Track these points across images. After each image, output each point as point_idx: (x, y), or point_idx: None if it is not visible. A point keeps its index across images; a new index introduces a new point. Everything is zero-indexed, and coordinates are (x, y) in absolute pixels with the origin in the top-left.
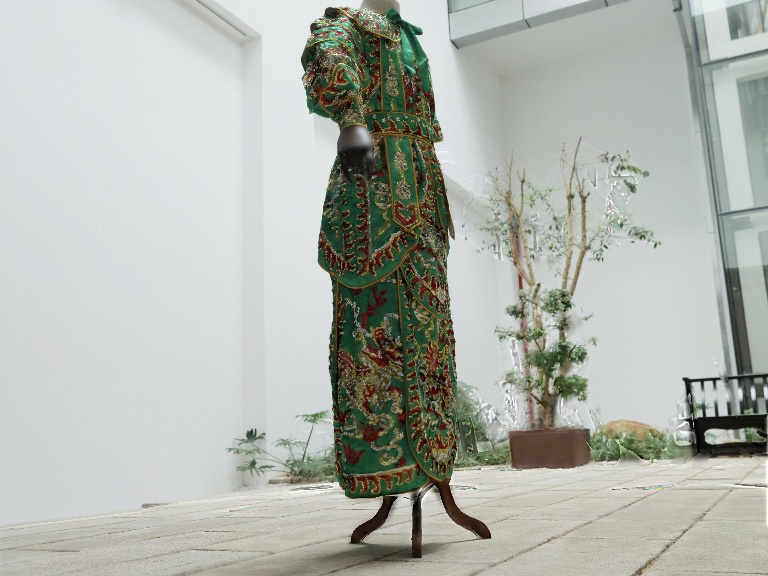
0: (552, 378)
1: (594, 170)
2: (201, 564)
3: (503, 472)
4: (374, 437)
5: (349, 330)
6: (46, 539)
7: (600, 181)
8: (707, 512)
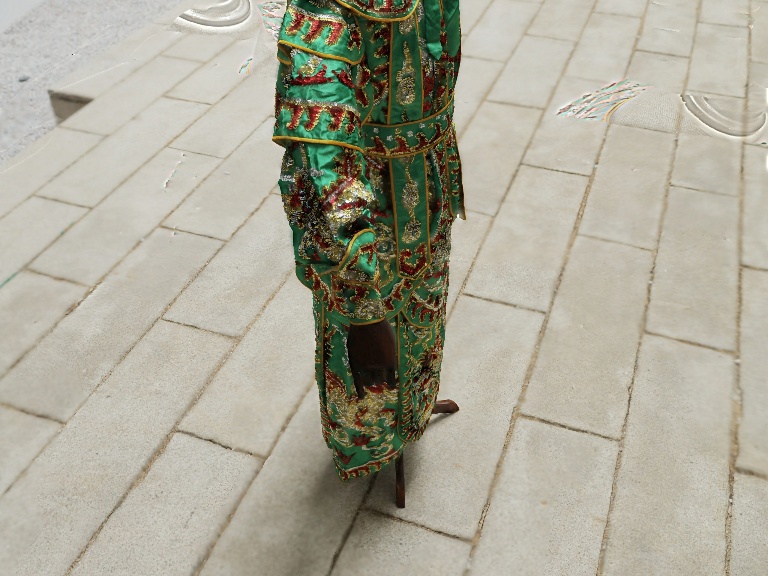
0: None
1: None
2: (206, 520)
3: None
4: (366, 443)
5: (338, 354)
6: (7, 347)
7: None
8: (652, 287)
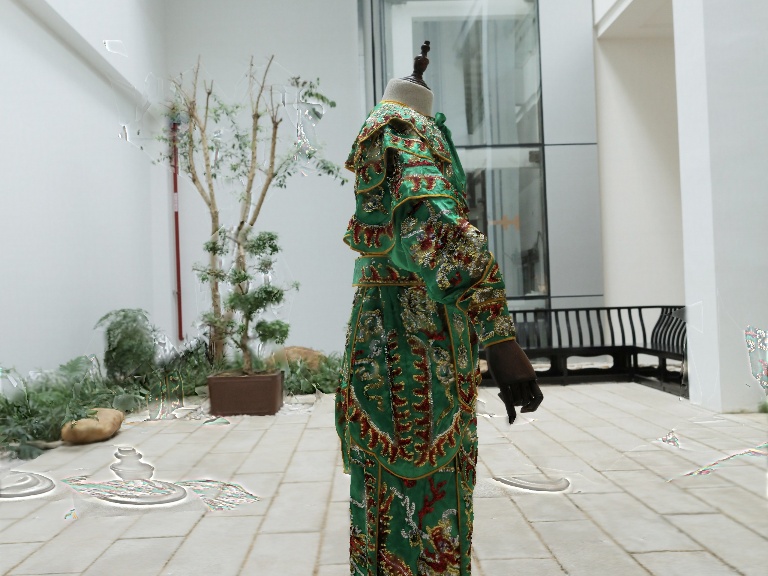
0: (251, 320)
1: (282, 92)
2: None
3: (215, 430)
4: None
5: (397, 528)
6: None
7: (289, 105)
8: None
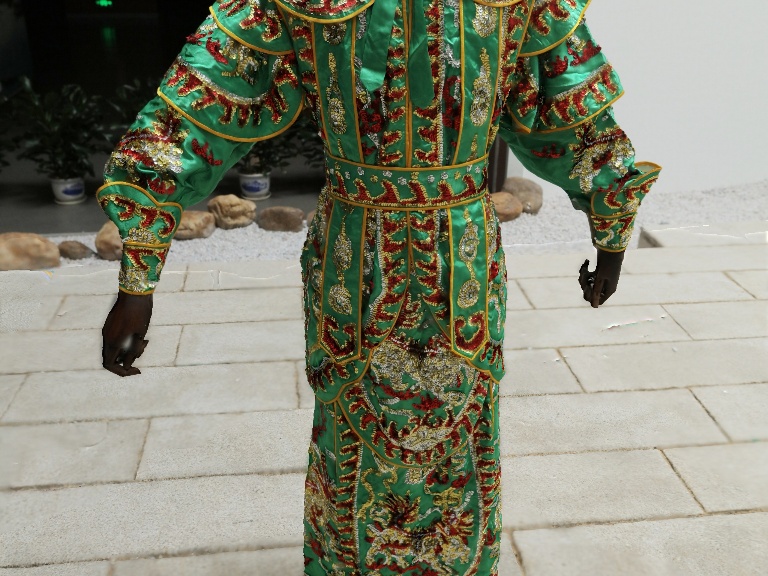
0: None
1: None
2: (248, 533)
3: None
4: (320, 555)
5: None
6: None
7: None
8: None
